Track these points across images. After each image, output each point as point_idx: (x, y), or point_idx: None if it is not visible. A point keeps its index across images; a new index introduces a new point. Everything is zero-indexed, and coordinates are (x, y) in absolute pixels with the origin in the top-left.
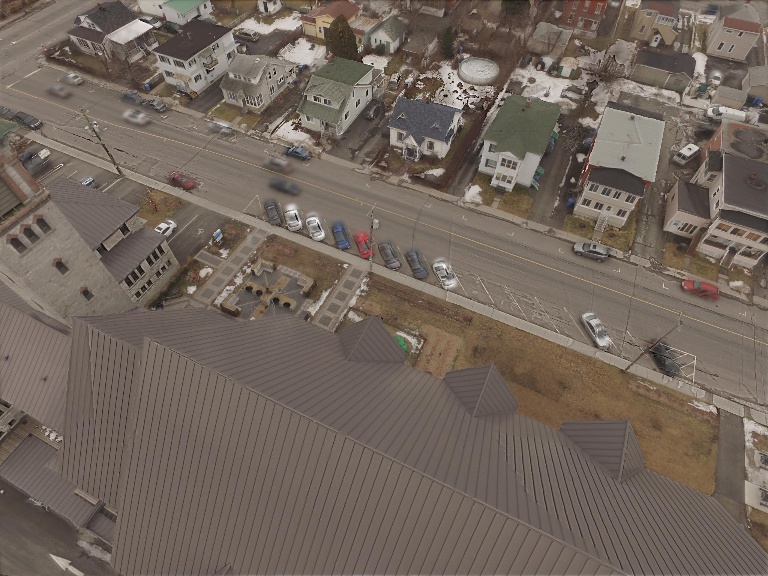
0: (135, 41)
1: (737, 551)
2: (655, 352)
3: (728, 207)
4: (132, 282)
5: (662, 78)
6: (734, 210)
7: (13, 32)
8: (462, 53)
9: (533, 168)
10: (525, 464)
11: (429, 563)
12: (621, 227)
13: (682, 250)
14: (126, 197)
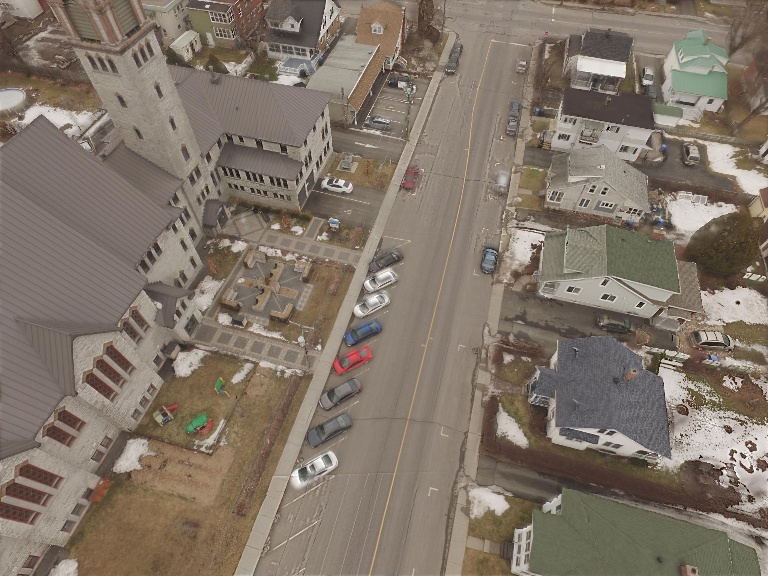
0: (593, 76)
1: None
2: None
3: None
4: (251, 179)
5: None
6: None
7: (568, 14)
8: None
9: None
10: None
11: None
12: None
13: None
14: (381, 151)
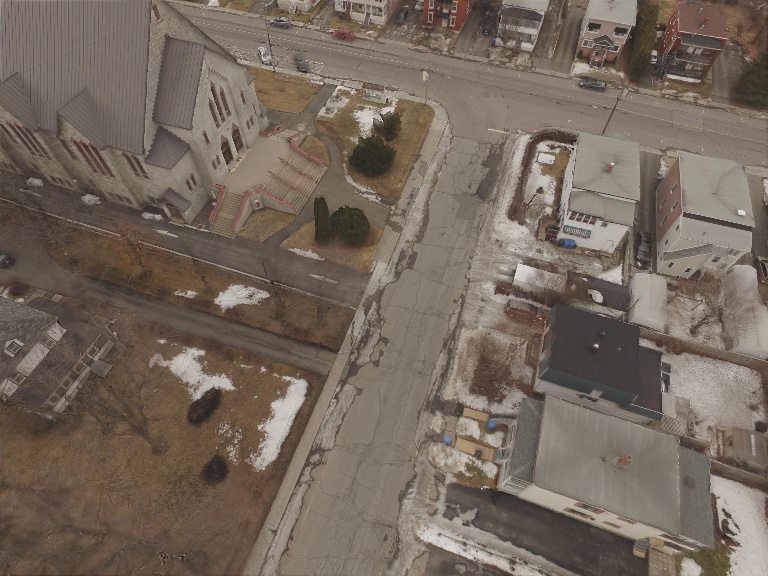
0: None
1: None
2: (300, 64)
3: None
4: None
5: None
6: None
7: None
8: None
9: None
10: None
11: (17, 8)
12: (307, 11)
13: (342, 19)
14: None
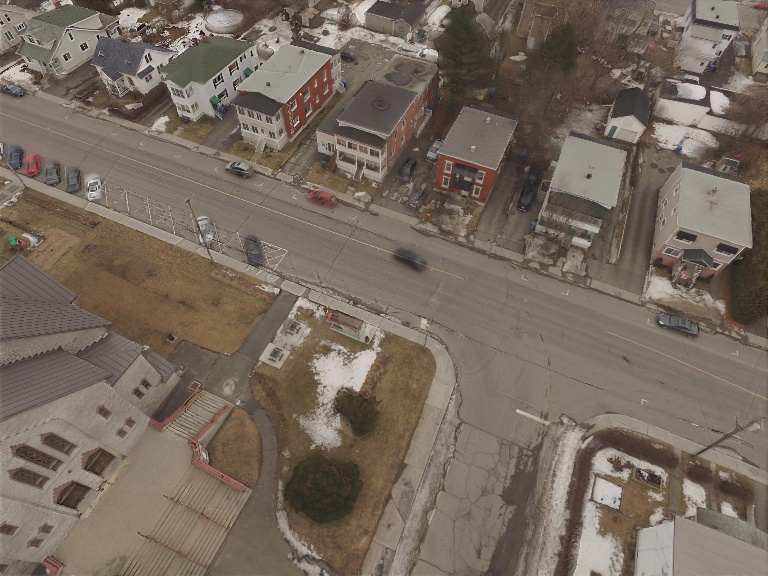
0: None
1: None
2: (253, 248)
3: (341, 123)
4: None
5: (389, 26)
6: (347, 126)
7: None
8: (214, 5)
9: (206, 98)
10: None
11: None
12: (280, 149)
13: (325, 167)
14: None
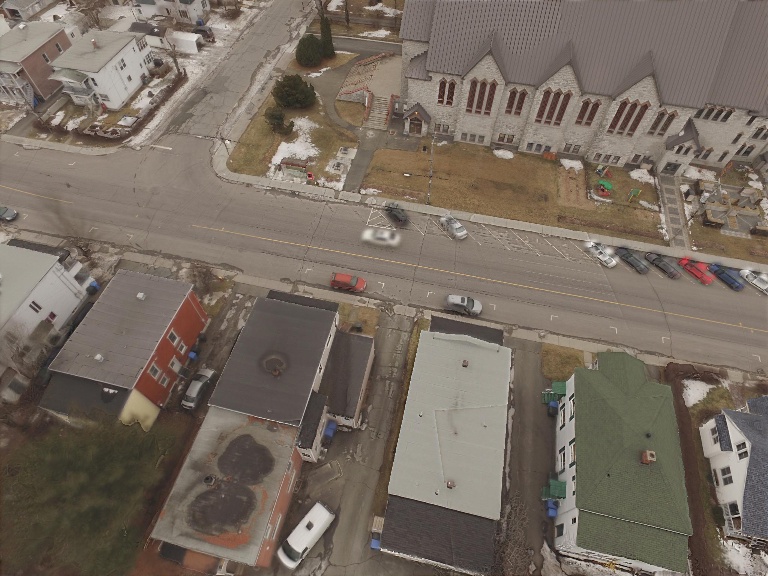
0: None
1: (455, 2)
2: (401, 223)
3: None
4: None
5: None
6: None
7: None
8: None
9: None
10: (551, 1)
11: None
12: None
13: None
14: None
